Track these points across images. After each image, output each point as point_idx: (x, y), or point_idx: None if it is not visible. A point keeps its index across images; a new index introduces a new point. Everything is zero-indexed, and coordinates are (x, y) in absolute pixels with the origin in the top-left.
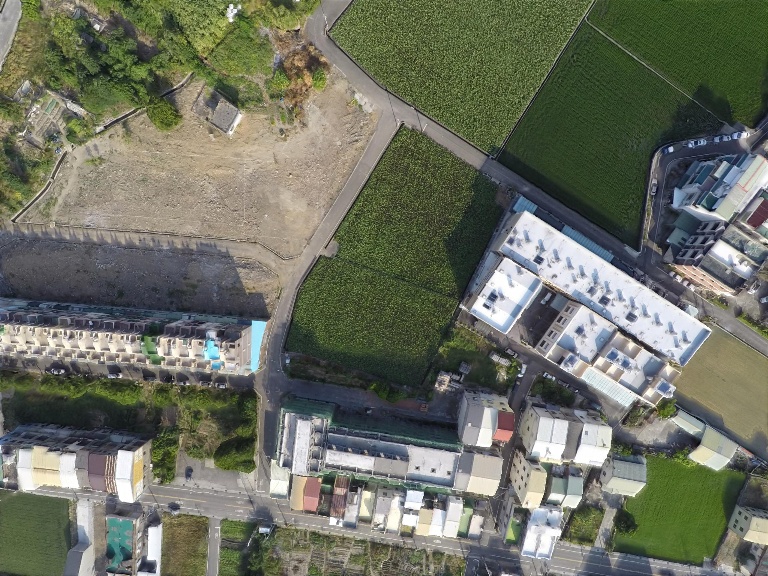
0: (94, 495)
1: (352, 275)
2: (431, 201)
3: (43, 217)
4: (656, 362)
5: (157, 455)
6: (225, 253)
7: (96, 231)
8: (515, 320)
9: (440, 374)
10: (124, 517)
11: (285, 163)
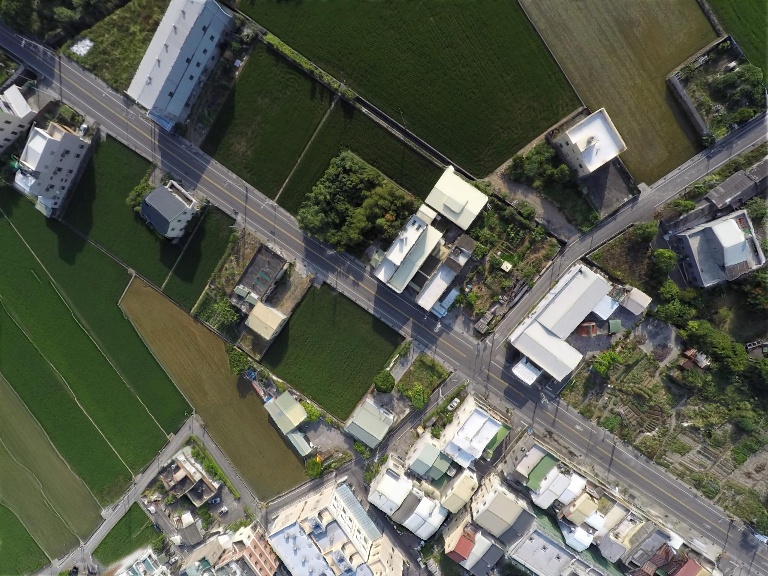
0: None
1: None
2: None
3: None
4: (315, 535)
5: None
6: None
7: None
8: None
9: None
10: None
11: None
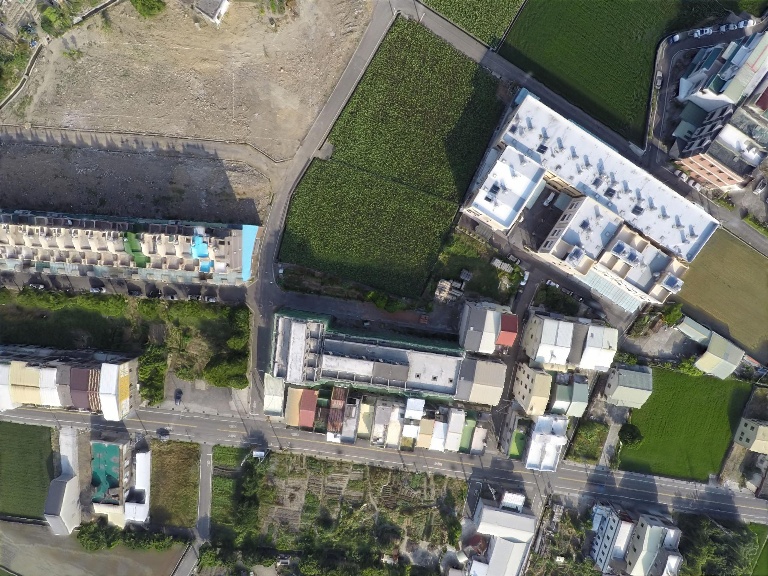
0: (78, 422)
1: (348, 178)
2: (429, 97)
3: (18, 118)
4: (663, 258)
5: (144, 373)
6: (213, 155)
7: (75, 133)
8: (518, 213)
9: (440, 280)
10: (110, 442)
11: (276, 56)
